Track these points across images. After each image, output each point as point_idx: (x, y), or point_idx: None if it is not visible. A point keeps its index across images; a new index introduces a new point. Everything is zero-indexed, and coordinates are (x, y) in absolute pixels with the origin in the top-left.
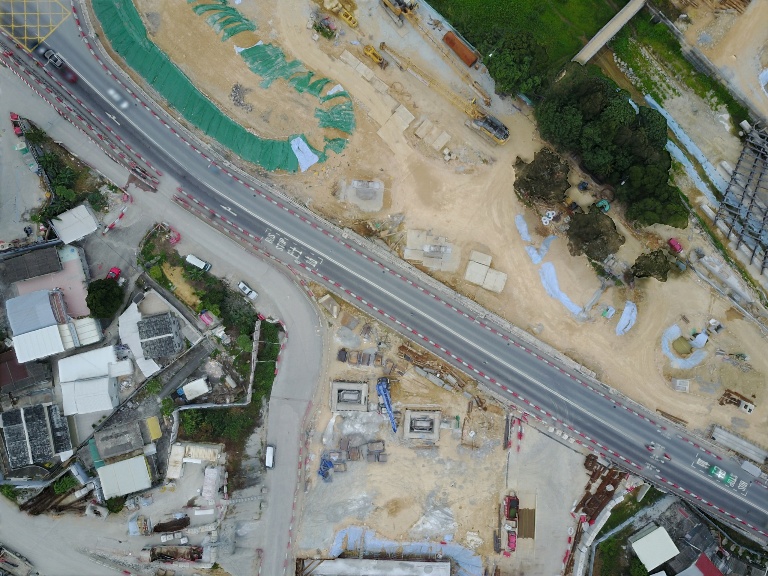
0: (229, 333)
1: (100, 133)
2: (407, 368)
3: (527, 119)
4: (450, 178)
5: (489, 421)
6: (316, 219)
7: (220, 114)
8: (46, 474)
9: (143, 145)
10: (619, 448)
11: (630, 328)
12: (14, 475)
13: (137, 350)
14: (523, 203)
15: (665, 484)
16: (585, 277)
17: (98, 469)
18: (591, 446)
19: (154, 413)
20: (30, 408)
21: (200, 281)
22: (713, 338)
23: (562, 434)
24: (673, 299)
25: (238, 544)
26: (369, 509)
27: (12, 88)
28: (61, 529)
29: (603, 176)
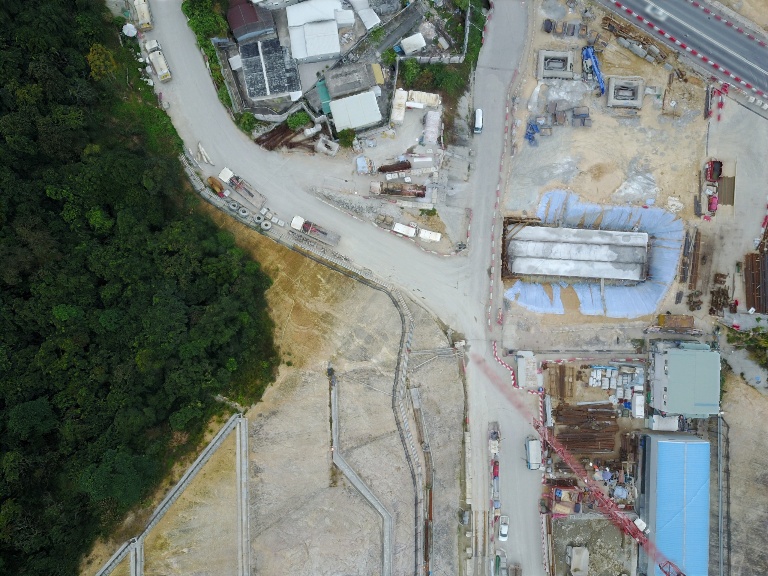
0: None
1: None
2: (610, 40)
3: None
4: None
5: (690, 92)
6: None
7: None
8: None
9: None
10: None
11: None
12: None
13: (358, 3)
14: None
15: None
16: None
17: (330, 103)
18: None
19: None
20: (267, 41)
21: None
22: None
23: (762, 104)
24: None
25: (448, 203)
26: (573, 173)
27: None
28: (290, 167)
29: None
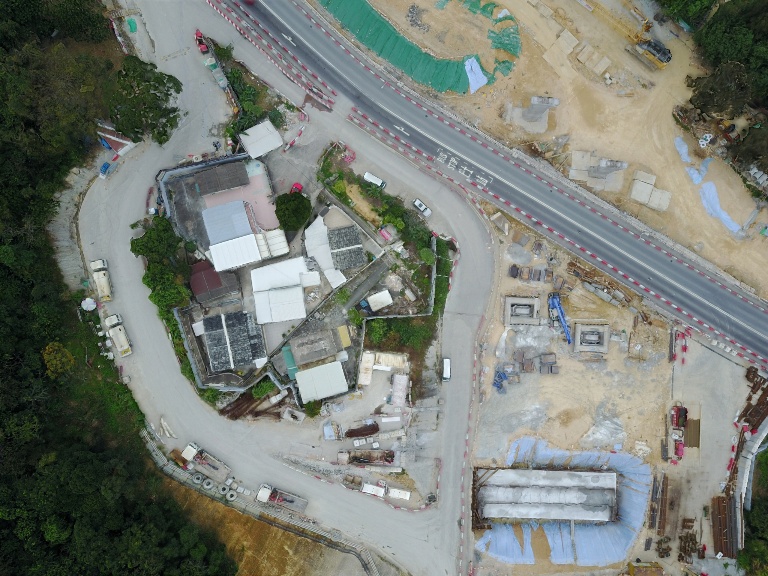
0: (407, 248)
1: (279, 53)
2: (575, 284)
3: (684, 45)
4: (612, 101)
5: (654, 335)
6: (486, 139)
7: (397, 34)
8: (240, 381)
9: (318, 66)
10: None
11: None
12: (211, 382)
13: (324, 262)
14: (681, 126)
15: None
16: (742, 197)
17: (296, 374)
18: (751, 359)
19: (340, 324)
20: (231, 314)
21: (377, 198)
22: None
23: (725, 347)
24: None
25: (417, 454)
26: (541, 420)
27: (194, 7)
28: (256, 434)
29: (762, 98)
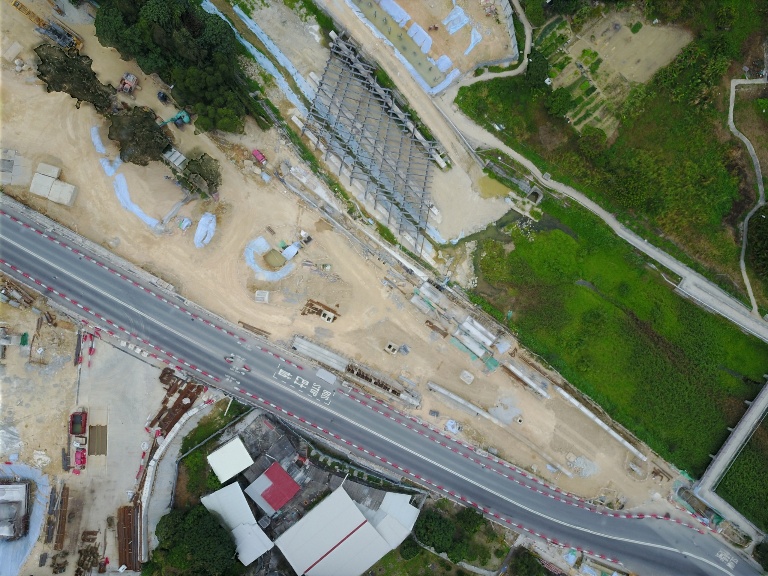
0: None
1: None
2: None
3: None
4: (20, 89)
5: (59, 337)
6: None
7: None
8: None
9: None
10: (197, 361)
11: (210, 240)
12: None
13: None
14: (102, 115)
15: (244, 396)
16: (164, 189)
17: None
18: (168, 360)
19: None
20: None
21: None
22: (305, 250)
23: (135, 348)
24: (259, 211)
25: None
26: None
27: None
28: None
29: None
